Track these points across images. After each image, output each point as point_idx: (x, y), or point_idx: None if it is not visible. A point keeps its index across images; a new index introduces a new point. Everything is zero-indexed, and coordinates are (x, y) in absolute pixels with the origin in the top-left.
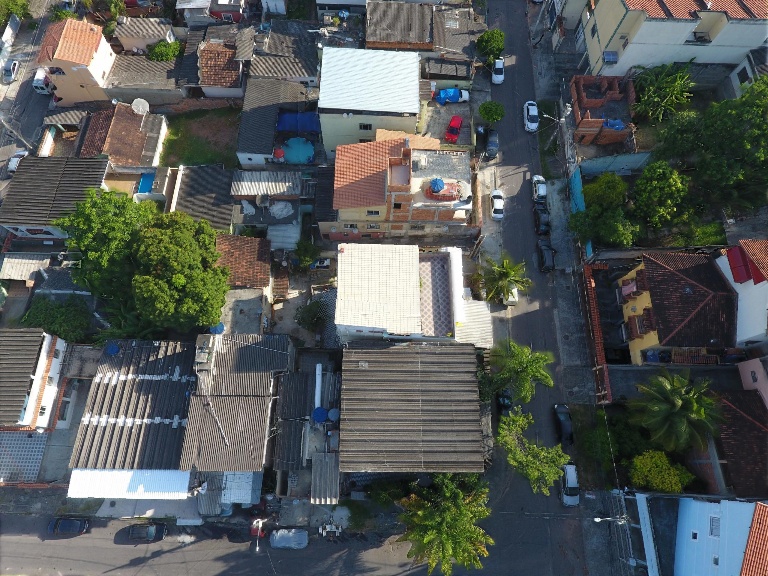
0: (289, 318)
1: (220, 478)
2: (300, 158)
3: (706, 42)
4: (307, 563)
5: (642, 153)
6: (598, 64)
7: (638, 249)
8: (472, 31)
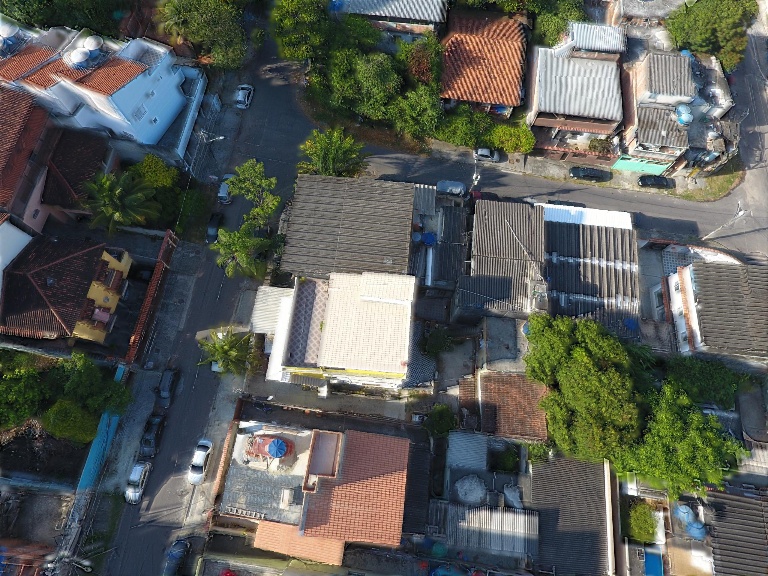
0: (456, 363)
1: None
2: None
3: None
4: (437, 174)
5: None
6: None
7: (68, 356)
8: None
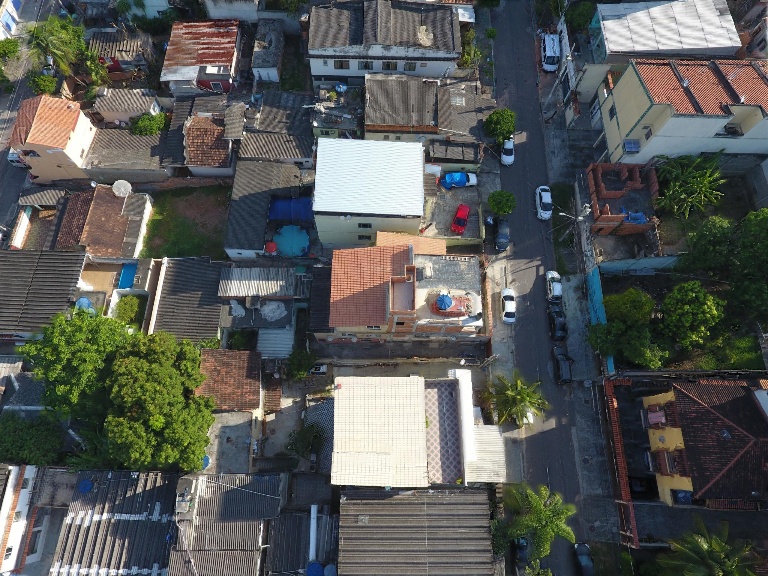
0: (282, 431)
1: None
2: (294, 249)
3: (738, 135)
4: None
5: (668, 257)
6: (617, 151)
7: (666, 371)
8: (480, 108)
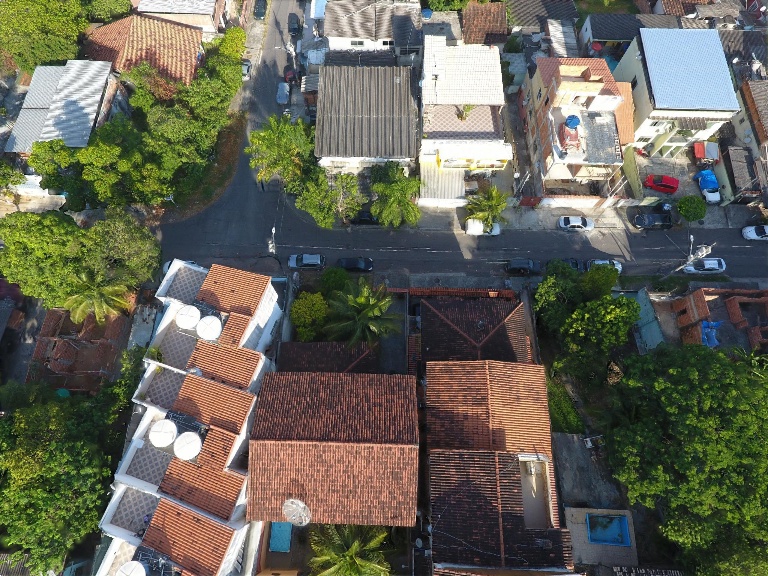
0: None
1: (324, 46)
2: None
3: None
4: (267, 106)
5: None
6: None
7: (533, 320)
8: None
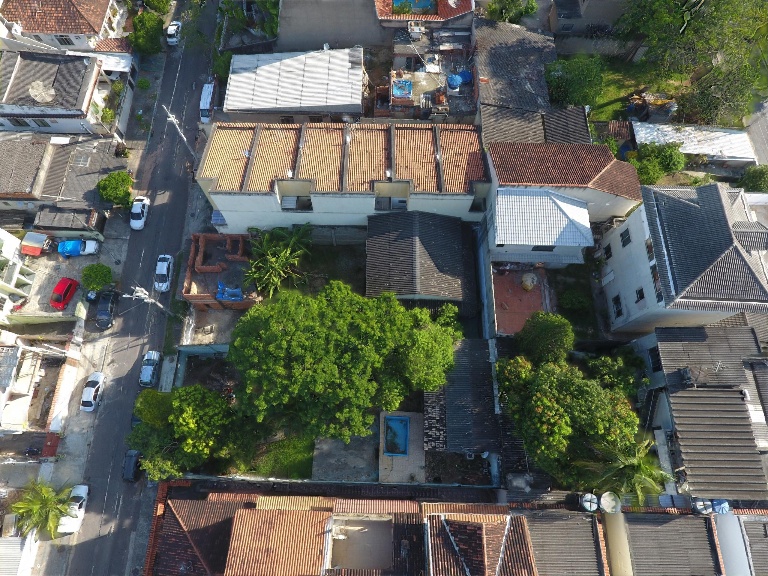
0: None
1: None
2: None
3: (307, 210)
4: None
5: None
6: None
7: None
8: (105, 169)
